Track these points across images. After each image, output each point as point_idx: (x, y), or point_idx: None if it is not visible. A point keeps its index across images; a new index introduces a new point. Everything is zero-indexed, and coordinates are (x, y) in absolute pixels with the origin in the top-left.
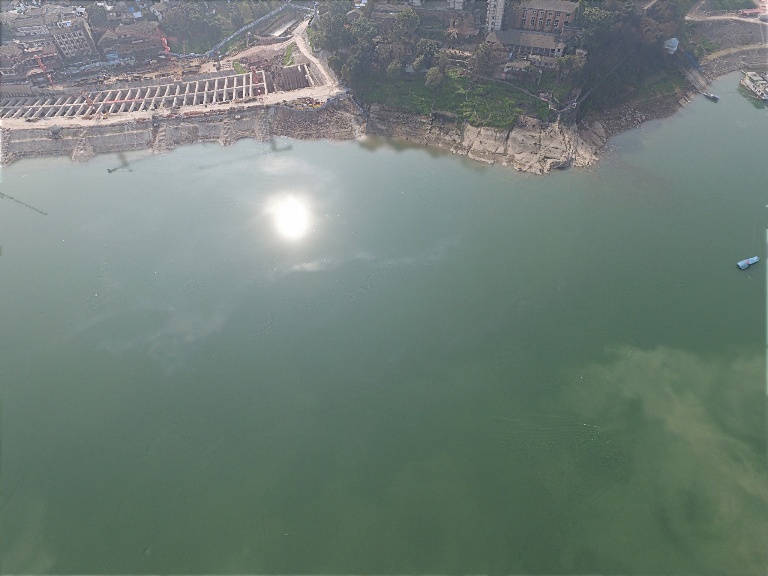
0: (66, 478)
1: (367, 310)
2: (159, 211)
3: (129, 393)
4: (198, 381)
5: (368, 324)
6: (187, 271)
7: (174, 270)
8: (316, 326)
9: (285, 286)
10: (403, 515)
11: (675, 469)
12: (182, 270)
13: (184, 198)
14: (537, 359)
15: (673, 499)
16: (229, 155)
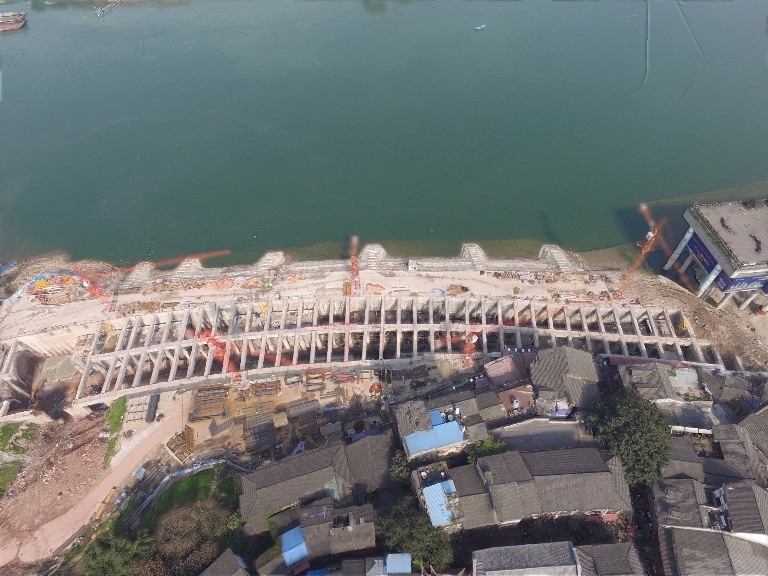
0: (293, 64)
1: (132, 113)
2: (269, 183)
3: (271, 85)
4: (236, 88)
5: (136, 109)
6: (244, 139)
7: (254, 141)
8: (167, 113)
9: (177, 127)
10: (162, 66)
11: (46, 64)
12: (248, 141)
13: (246, 194)
14: (60, 94)
15: (57, 55)
16: (193, 246)
